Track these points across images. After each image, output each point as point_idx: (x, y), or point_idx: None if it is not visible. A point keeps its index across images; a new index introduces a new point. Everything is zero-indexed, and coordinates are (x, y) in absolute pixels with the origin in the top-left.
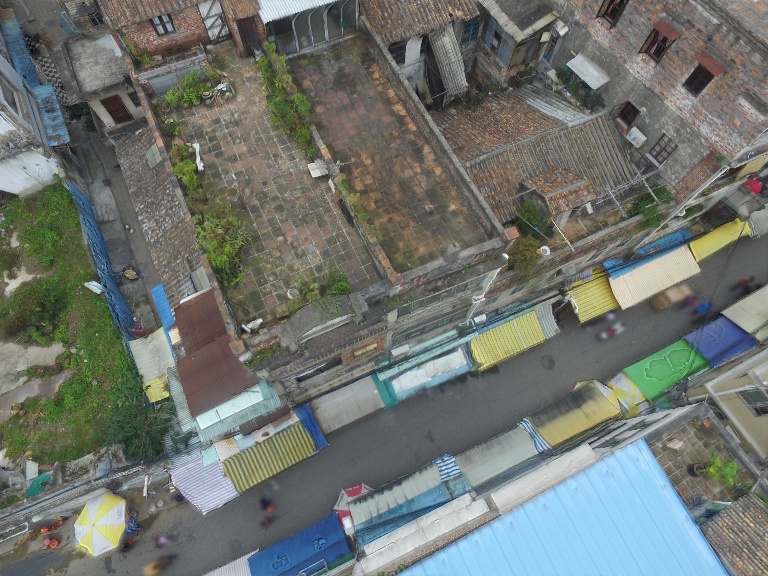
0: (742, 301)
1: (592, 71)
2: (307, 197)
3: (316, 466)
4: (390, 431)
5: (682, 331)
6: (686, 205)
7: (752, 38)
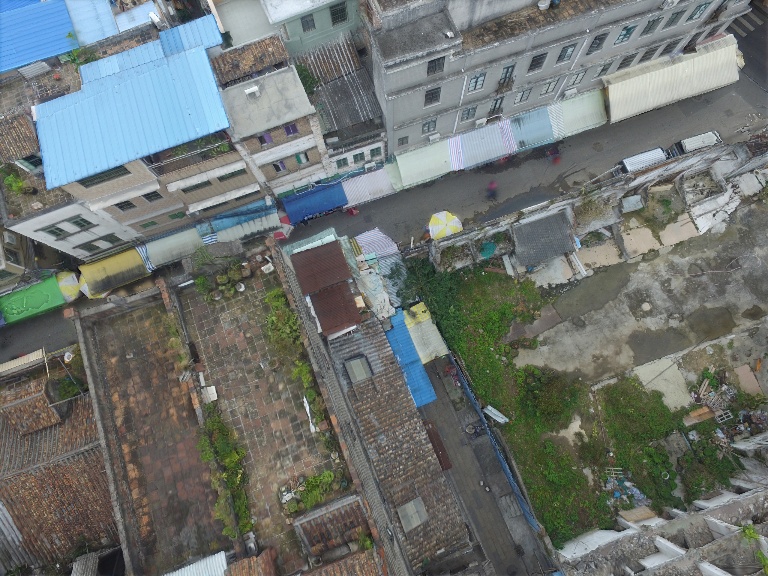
0: None
1: None
2: (224, 372)
3: None
4: None
5: (6, 341)
6: None
7: None
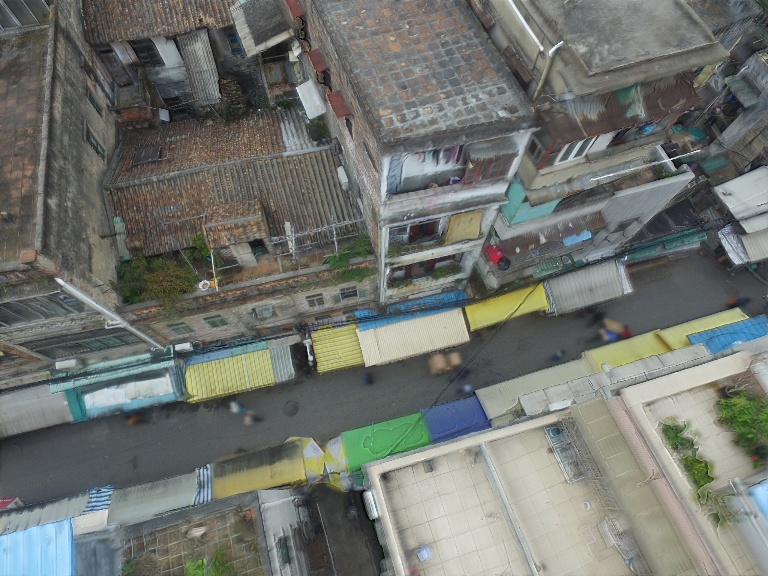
0: (504, 382)
1: (315, 99)
2: None
3: (7, 468)
4: (97, 448)
5: None
6: (393, 263)
7: (351, 79)
